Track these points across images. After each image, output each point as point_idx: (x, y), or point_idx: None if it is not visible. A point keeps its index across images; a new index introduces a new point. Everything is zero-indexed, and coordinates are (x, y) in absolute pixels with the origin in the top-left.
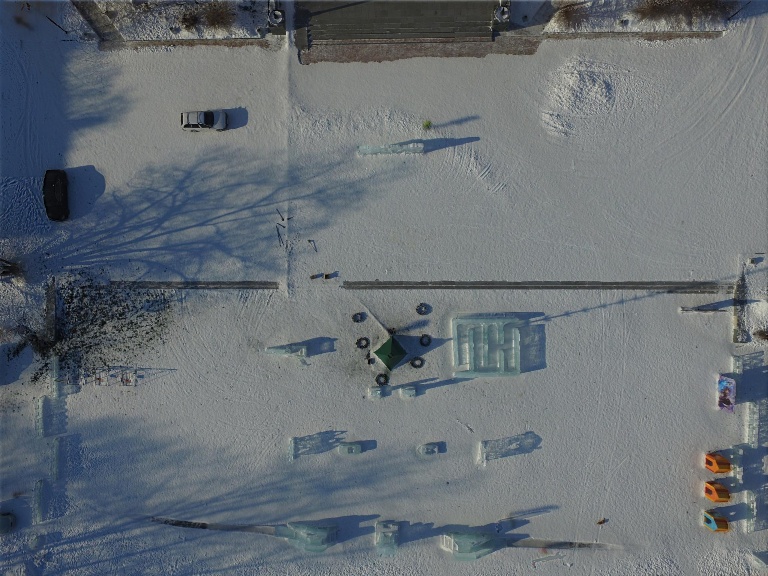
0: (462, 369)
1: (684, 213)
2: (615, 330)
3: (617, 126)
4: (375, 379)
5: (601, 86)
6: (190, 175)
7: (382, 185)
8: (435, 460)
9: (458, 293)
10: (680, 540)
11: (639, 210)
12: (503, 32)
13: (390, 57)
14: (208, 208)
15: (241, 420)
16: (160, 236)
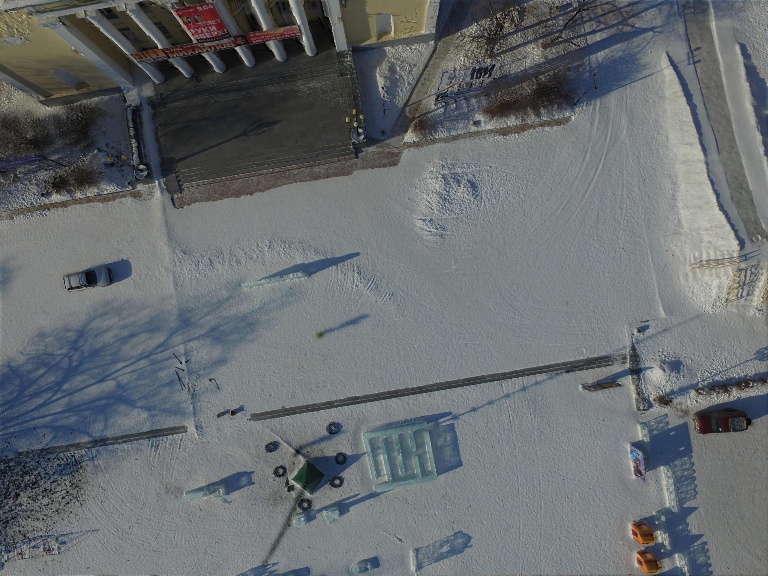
0: (381, 481)
1: (567, 294)
2: (522, 417)
3: (488, 221)
4: (297, 506)
5: (466, 186)
6: (83, 334)
7: (273, 313)
8: None
9: (364, 407)
10: None
11: (524, 298)
12: (365, 148)
13: (261, 188)
14: (105, 364)
15: (171, 570)
16: (61, 399)
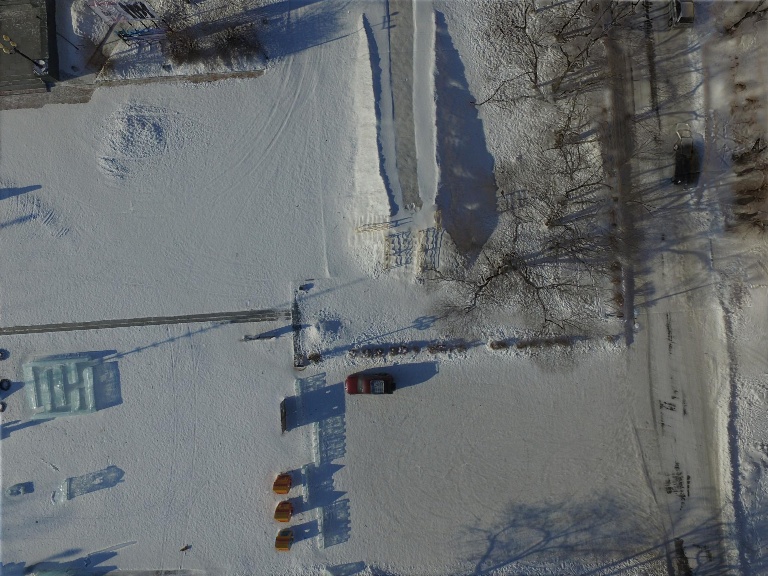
0: (42, 410)
1: (238, 246)
2: (185, 362)
3: (170, 166)
4: None
5: (150, 129)
6: None
7: None
8: (24, 500)
9: (32, 337)
10: (259, 560)
11: (196, 246)
12: (58, 82)
13: None
14: None
15: None
16: None
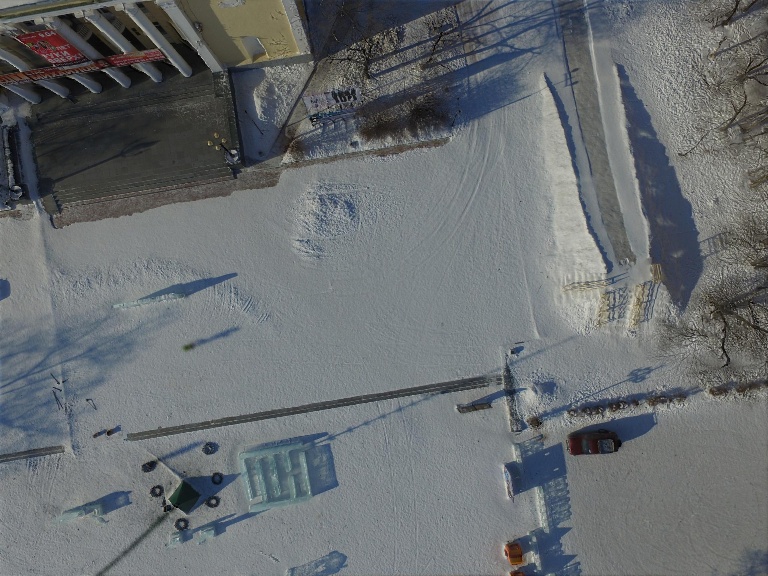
0: (257, 501)
1: (442, 315)
2: (398, 438)
3: (365, 242)
4: (174, 525)
5: (343, 207)
6: None
7: (150, 334)
8: None
9: (241, 427)
10: None
11: (399, 319)
12: (244, 169)
13: (140, 209)
14: None
15: None
16: None
